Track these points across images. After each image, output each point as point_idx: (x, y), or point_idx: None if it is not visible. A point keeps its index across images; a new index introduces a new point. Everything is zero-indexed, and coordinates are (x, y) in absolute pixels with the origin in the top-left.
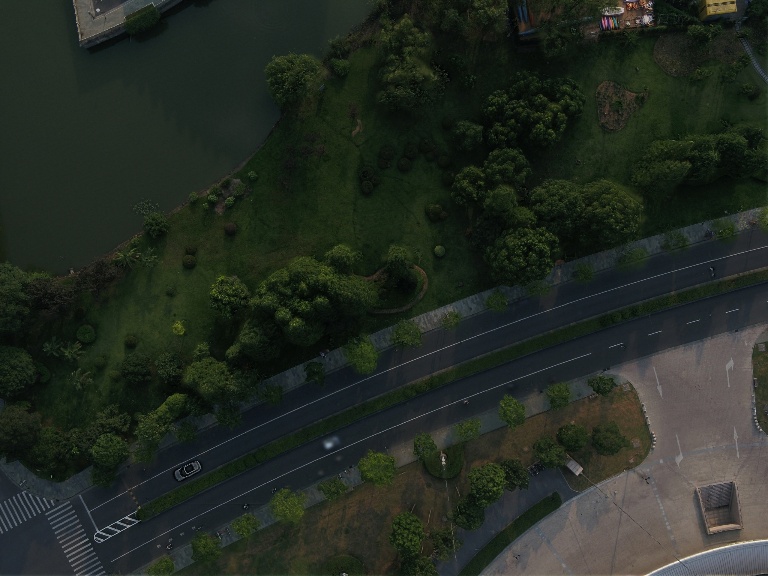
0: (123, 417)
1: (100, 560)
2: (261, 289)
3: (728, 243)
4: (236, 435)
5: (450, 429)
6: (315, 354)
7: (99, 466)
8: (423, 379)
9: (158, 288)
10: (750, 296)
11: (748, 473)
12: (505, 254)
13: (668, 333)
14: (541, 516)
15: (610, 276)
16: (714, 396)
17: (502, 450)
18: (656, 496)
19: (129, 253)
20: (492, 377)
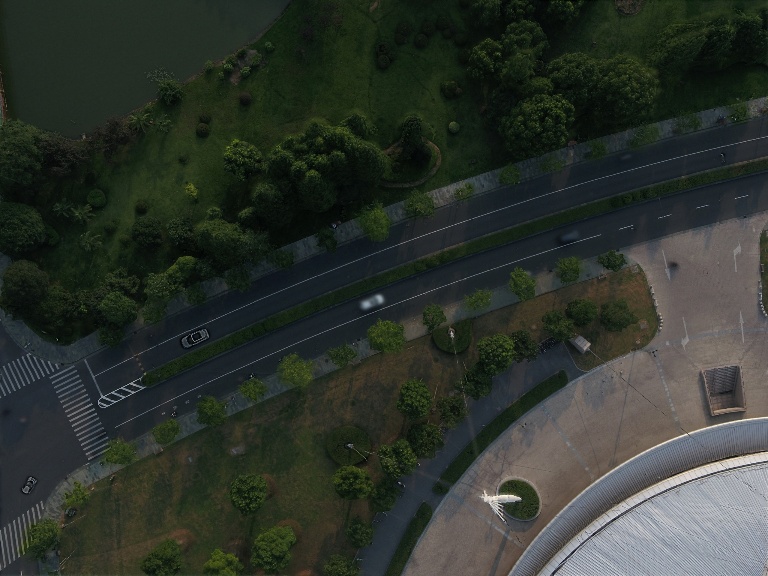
0: (132, 279)
1: (103, 426)
2: (277, 148)
3: (739, 130)
4: (245, 304)
5: (459, 305)
6: (327, 226)
7: (107, 324)
8: (434, 254)
9: (171, 155)
10: (759, 183)
11: (753, 357)
12: (521, 119)
13: (678, 217)
14: (547, 393)
15: (622, 158)
16: (721, 280)
17: (510, 327)
18: (661, 377)
19: (143, 117)
20: (502, 255)
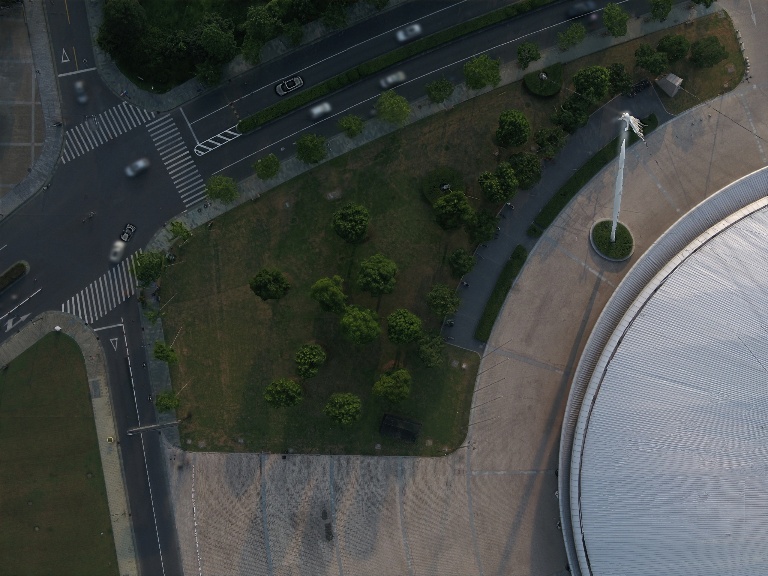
0: (228, 21)
1: (200, 173)
2: None
3: None
4: (338, 52)
5: (549, 51)
6: None
7: (207, 58)
8: (523, 0)
9: None
10: None
11: None
12: None
13: None
14: None
15: None
16: None
17: None
18: (749, 120)
19: None
20: (591, 2)
